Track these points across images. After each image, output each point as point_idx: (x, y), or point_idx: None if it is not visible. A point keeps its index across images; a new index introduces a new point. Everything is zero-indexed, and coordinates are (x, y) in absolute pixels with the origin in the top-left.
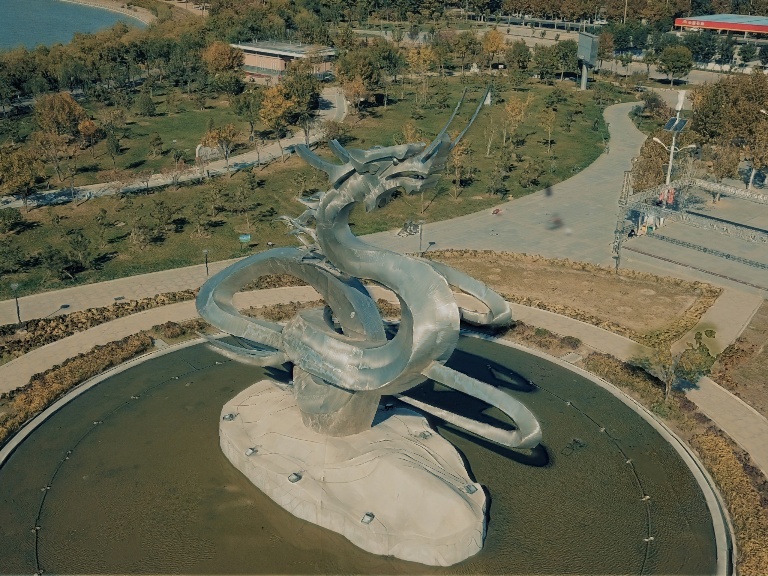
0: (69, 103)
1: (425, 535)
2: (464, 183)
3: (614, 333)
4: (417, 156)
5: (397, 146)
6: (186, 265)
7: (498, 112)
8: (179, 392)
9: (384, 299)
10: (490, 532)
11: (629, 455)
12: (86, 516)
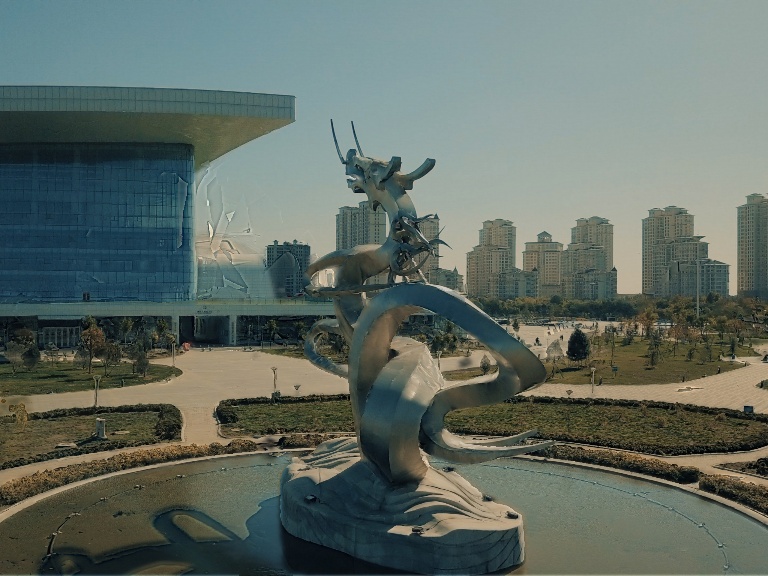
0: None
1: None
2: None
3: None
4: None
5: None
6: None
7: None
8: None
9: None
10: None
11: None
12: None
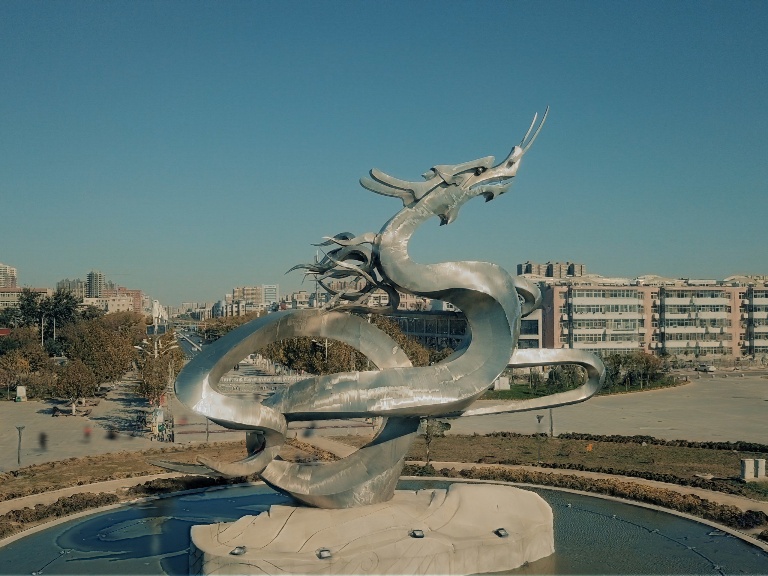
0: None
1: (543, 523)
2: None
3: None
4: (500, 164)
5: None
6: None
7: None
8: None
9: (81, 493)
10: None
11: None
12: None
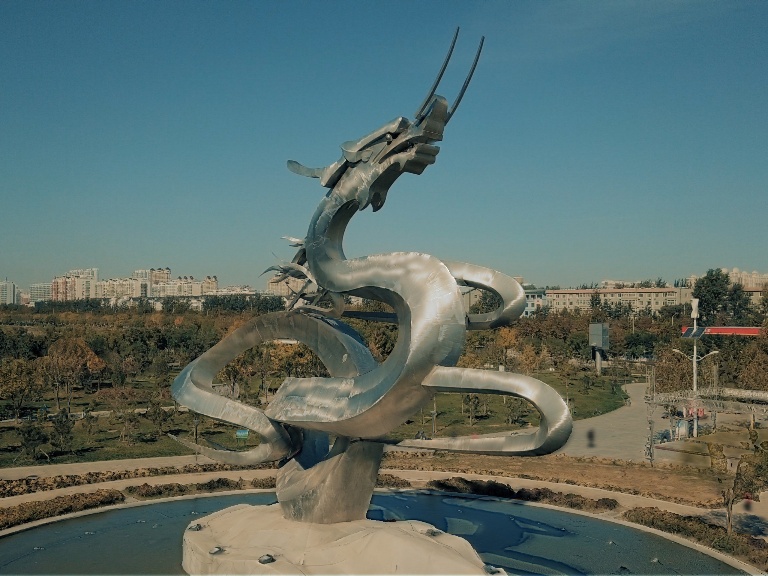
0: (82, 348)
1: None
2: (480, 418)
3: (656, 499)
4: None
5: None
6: (175, 455)
7: None
8: (143, 531)
9: (391, 474)
10: None
11: None
12: None
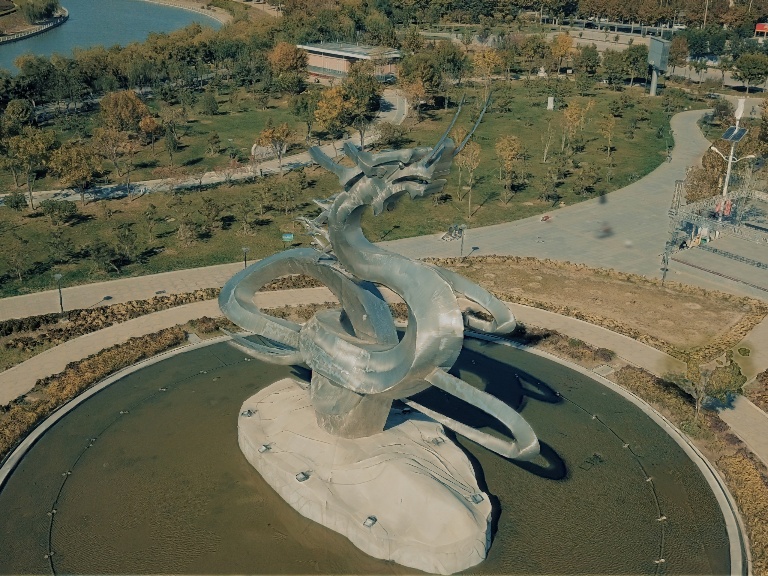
0: (133, 100)
1: (425, 542)
2: (516, 188)
3: (651, 347)
4: (421, 161)
5: (402, 150)
6: (229, 262)
7: (560, 117)
8: (206, 386)
9: None
10: (495, 543)
11: (650, 473)
12: (102, 503)
